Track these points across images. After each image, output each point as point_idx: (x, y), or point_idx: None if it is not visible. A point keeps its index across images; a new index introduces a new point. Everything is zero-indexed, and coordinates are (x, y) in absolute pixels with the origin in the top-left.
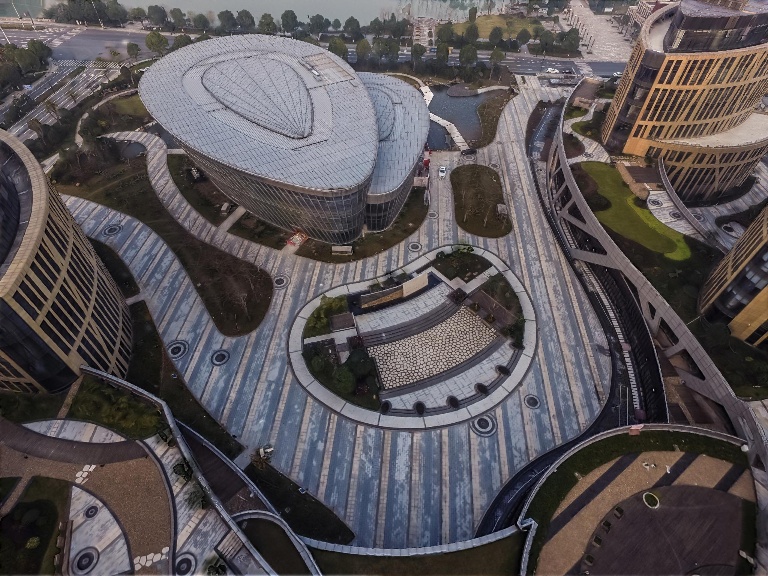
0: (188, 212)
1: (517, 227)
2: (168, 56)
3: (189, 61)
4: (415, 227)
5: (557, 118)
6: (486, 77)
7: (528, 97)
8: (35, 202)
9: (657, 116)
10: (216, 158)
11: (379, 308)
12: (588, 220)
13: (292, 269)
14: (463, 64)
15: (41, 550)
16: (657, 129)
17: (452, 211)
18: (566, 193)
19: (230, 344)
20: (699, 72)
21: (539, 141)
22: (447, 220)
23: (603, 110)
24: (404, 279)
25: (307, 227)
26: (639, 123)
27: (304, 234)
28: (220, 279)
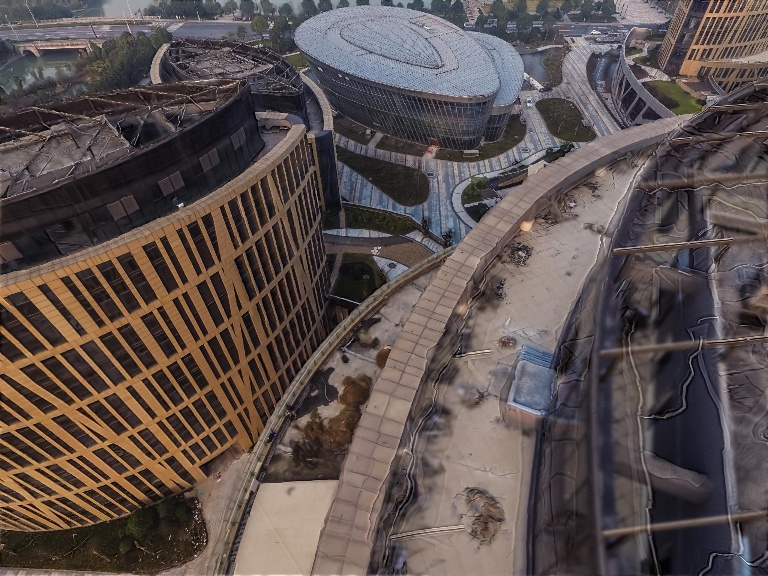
0: (339, 137)
1: (600, 135)
2: (306, 22)
3: (324, 25)
4: (520, 138)
5: (610, 64)
6: (541, 39)
7: (581, 52)
8: (312, 89)
9: (707, 40)
10: (381, 82)
11: (512, 186)
12: (664, 115)
13: (436, 167)
14: (520, 30)
15: (372, 281)
16: (707, 52)
17: (545, 127)
18: (635, 109)
19: (411, 210)
20: (741, 1)
21: (600, 80)
22: (544, 133)
23: (655, 48)
24: (525, 168)
25: (443, 137)
26: (693, 47)
27: (437, 146)
28: (386, 174)
